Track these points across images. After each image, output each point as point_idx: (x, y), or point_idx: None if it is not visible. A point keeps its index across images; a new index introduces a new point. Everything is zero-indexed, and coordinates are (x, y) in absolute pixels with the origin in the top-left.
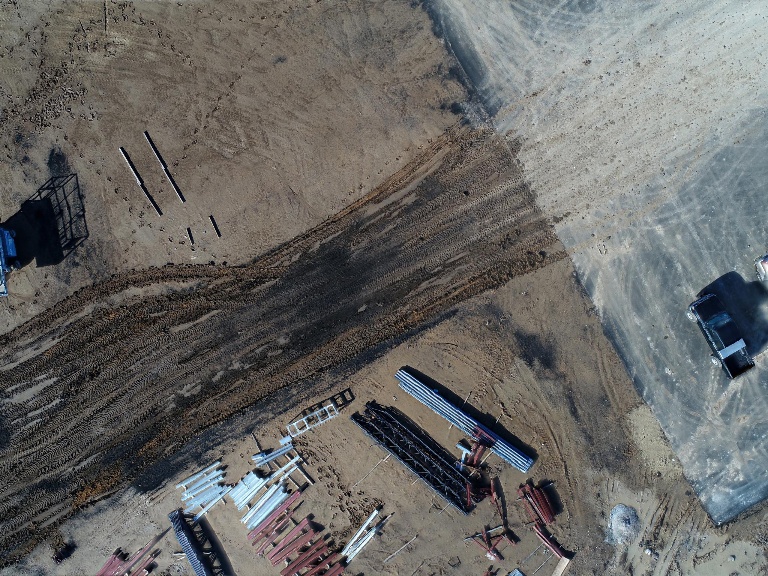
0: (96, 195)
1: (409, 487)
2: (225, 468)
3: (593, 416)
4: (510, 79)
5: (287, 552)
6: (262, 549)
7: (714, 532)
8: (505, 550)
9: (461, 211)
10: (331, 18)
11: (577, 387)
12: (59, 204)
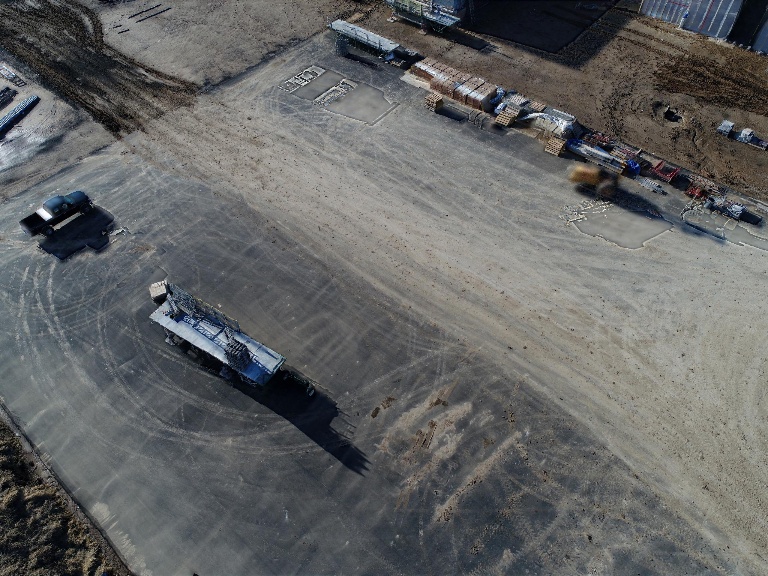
0: (136, 3)
1: None
2: None
3: None
4: (229, 95)
5: None
6: None
7: None
8: None
9: None
10: None
11: (22, 168)
12: None
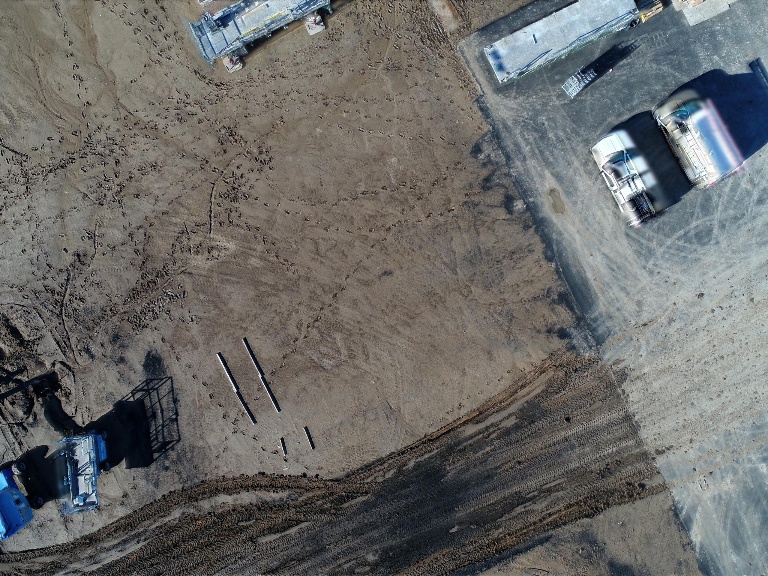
0: (190, 399)
1: None
2: None
3: None
4: (620, 308)
5: None
6: None
7: None
8: None
9: (561, 437)
10: (440, 234)
11: None
12: (152, 406)
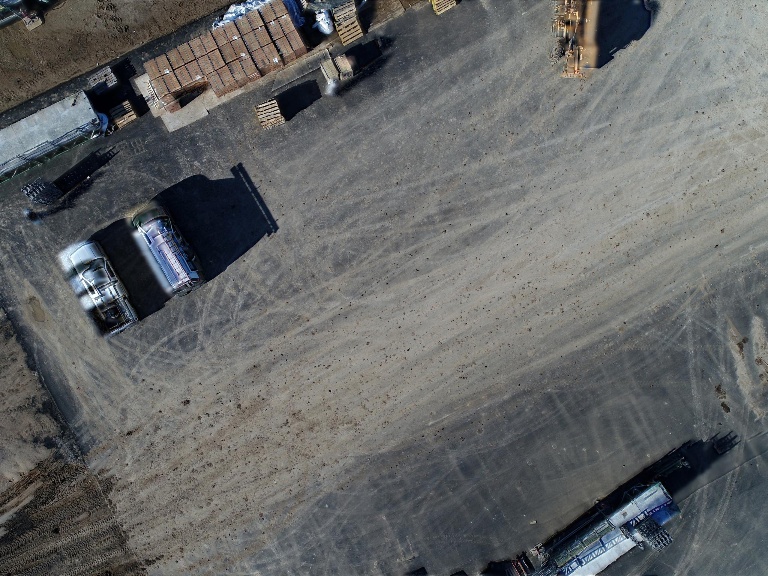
0: None
1: None
2: None
3: None
4: (104, 416)
5: None
6: None
7: None
8: None
9: (51, 548)
10: None
11: None
12: None
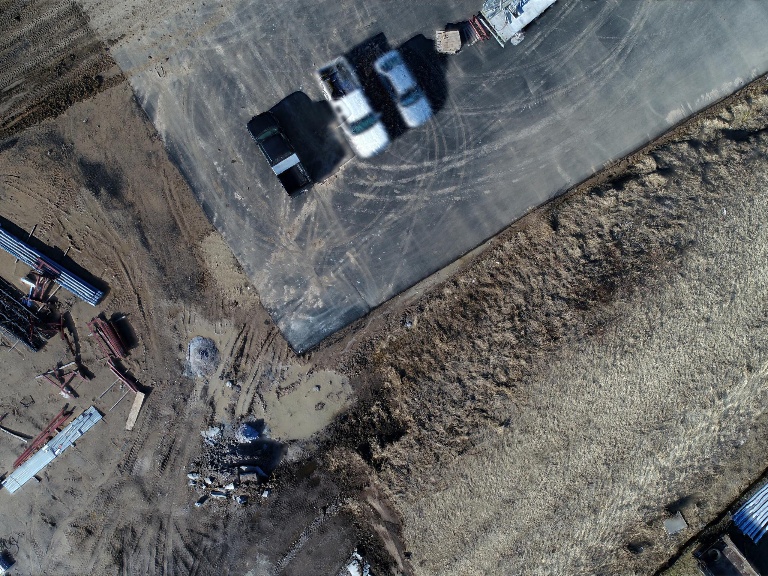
0: None
1: None
2: None
3: (164, 246)
4: None
5: None
6: None
7: (296, 362)
8: (80, 387)
9: (14, 37)
10: None
11: (146, 216)
12: None
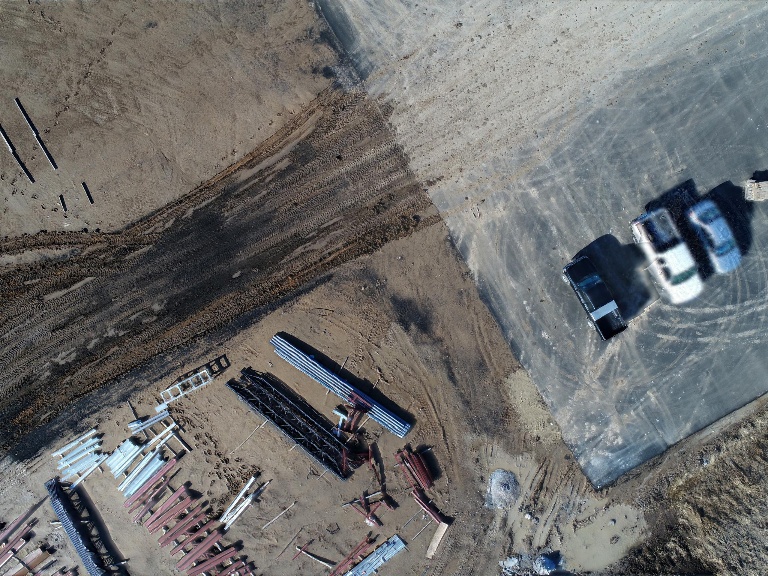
0: None
1: (287, 453)
2: (101, 436)
3: (471, 381)
4: (381, 42)
5: (164, 520)
6: (139, 517)
7: (594, 496)
8: (384, 516)
9: (334, 176)
10: None
11: (454, 352)
12: None
